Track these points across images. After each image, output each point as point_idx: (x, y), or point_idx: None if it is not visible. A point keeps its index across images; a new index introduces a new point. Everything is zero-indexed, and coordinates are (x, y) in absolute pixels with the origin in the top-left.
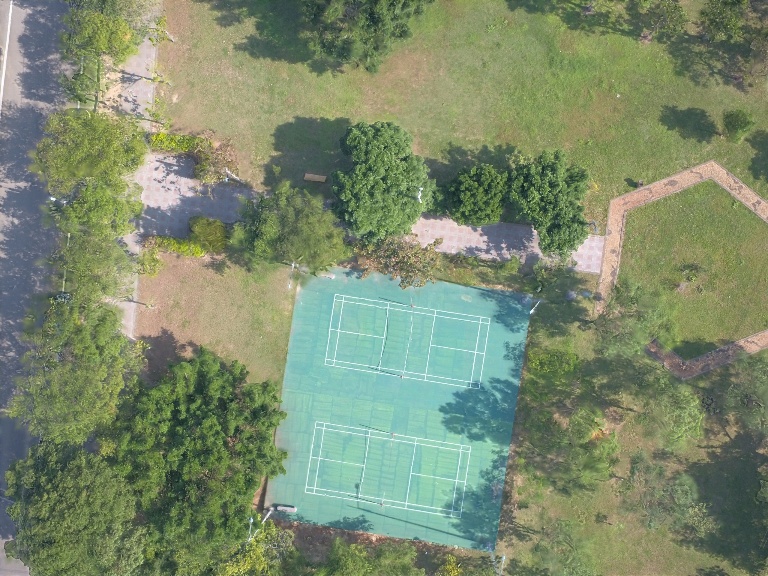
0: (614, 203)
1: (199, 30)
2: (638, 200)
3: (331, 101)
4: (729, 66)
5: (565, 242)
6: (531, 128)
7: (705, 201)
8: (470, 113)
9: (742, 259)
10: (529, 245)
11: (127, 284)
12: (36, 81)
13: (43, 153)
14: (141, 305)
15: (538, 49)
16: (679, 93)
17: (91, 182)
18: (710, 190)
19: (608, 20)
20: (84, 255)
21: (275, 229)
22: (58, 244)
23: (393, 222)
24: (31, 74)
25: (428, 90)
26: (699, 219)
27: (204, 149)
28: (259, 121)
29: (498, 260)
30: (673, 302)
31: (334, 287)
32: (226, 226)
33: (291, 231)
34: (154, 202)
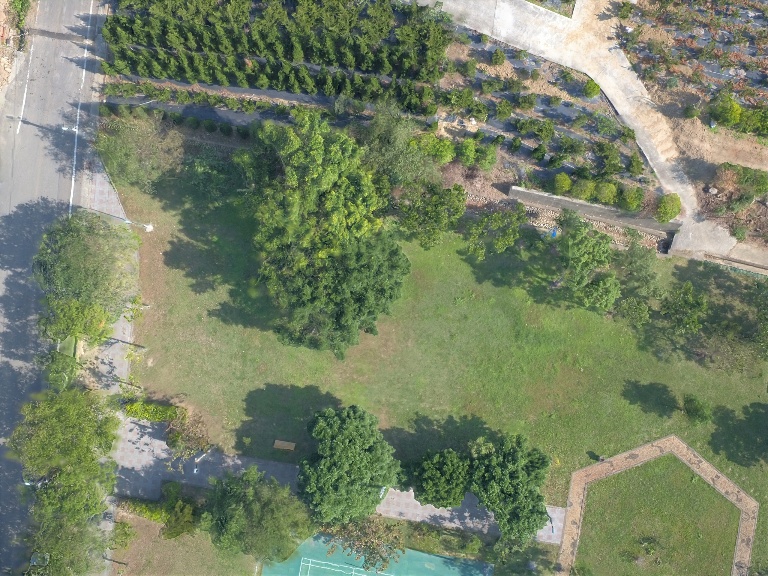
0: (576, 475)
1: (174, 296)
2: (599, 473)
3: (301, 369)
4: (691, 342)
5: (524, 529)
6: (496, 400)
7: (665, 475)
8: (437, 384)
9: (700, 533)
10: (492, 515)
11: (98, 563)
12: (16, 341)
13: (18, 441)
14: (114, 563)
15: (504, 322)
16: (642, 368)
17: (65, 467)
18: (670, 464)
19: (574, 294)
20: (57, 541)
21: (240, 529)
22: (35, 500)
23: (357, 511)
24: (11, 334)
25: (396, 360)
26: (659, 493)
27: (176, 427)
28: (231, 387)
29: (461, 529)
30: (631, 574)
31: (301, 551)
32: (193, 520)
33: (255, 535)
34: (128, 463)
